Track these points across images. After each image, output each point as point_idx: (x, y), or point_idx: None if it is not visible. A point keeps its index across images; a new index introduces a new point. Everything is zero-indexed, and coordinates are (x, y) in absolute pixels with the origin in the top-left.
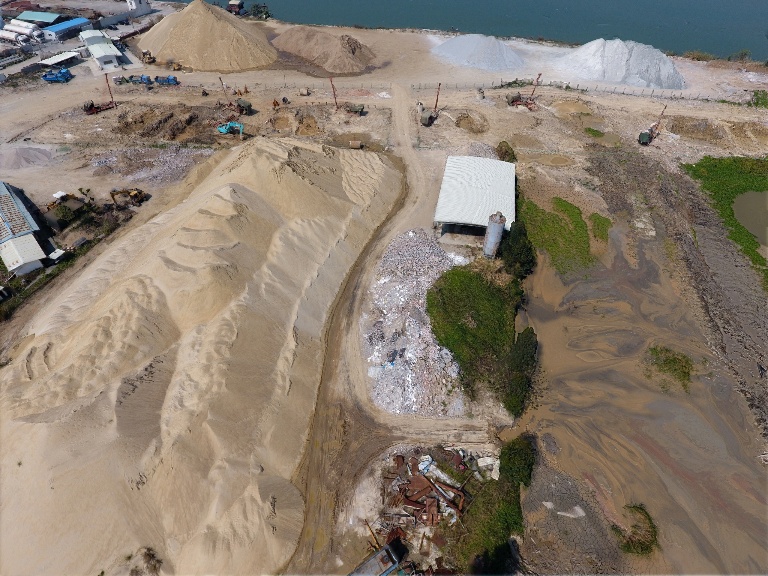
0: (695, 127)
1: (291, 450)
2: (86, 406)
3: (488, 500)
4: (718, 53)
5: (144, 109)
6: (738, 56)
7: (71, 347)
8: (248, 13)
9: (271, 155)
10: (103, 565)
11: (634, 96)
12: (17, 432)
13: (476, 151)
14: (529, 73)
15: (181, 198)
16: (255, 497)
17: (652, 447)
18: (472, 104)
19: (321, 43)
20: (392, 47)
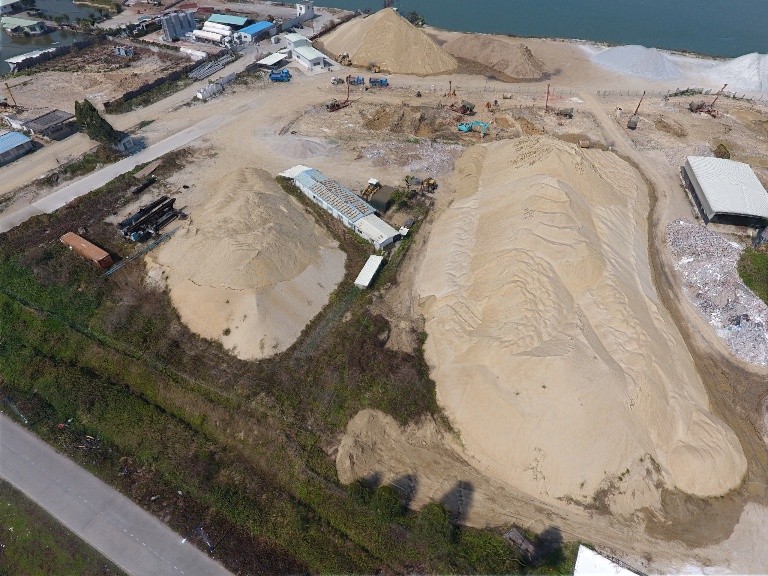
0: None
1: (700, 389)
2: (574, 345)
3: None
4: None
5: (376, 108)
6: None
7: (492, 304)
8: None
9: None
10: (626, 464)
11: None
12: (526, 364)
13: (702, 152)
14: (691, 83)
15: (475, 187)
16: (706, 421)
17: None
18: (659, 110)
19: (498, 50)
20: (553, 55)
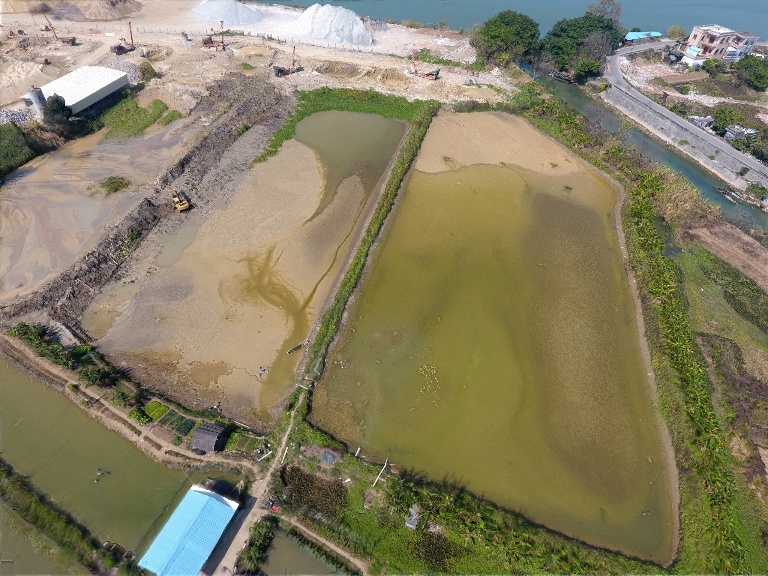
0: (343, 70)
1: None
2: None
3: None
4: None
5: None
6: (438, 25)
7: None
8: None
9: None
10: None
11: (320, 47)
12: None
13: (118, 67)
14: (254, 28)
15: None
16: None
17: (43, 217)
18: (174, 44)
19: None
20: (162, 5)
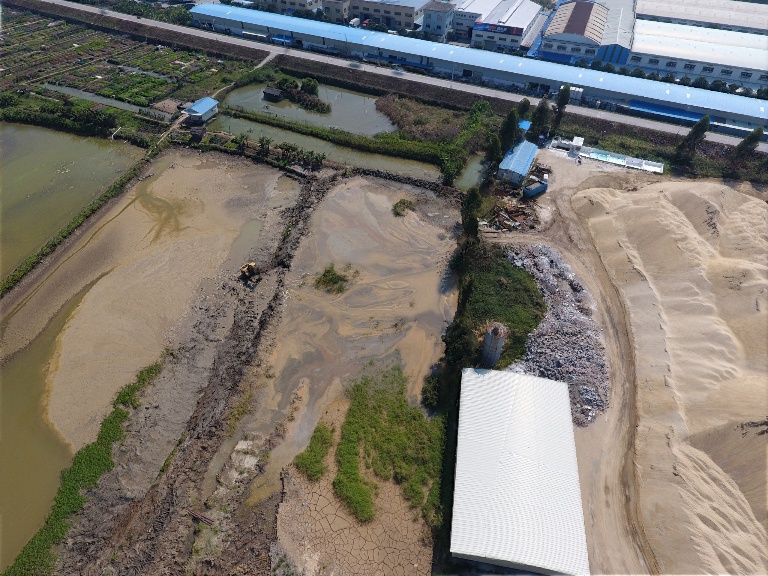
0: None
1: None
2: (720, 195)
3: None
4: None
5: None
6: None
7: None
8: None
9: None
10: None
11: None
12: None
13: None
14: None
15: None
16: None
17: (377, 237)
18: None
19: None
20: None
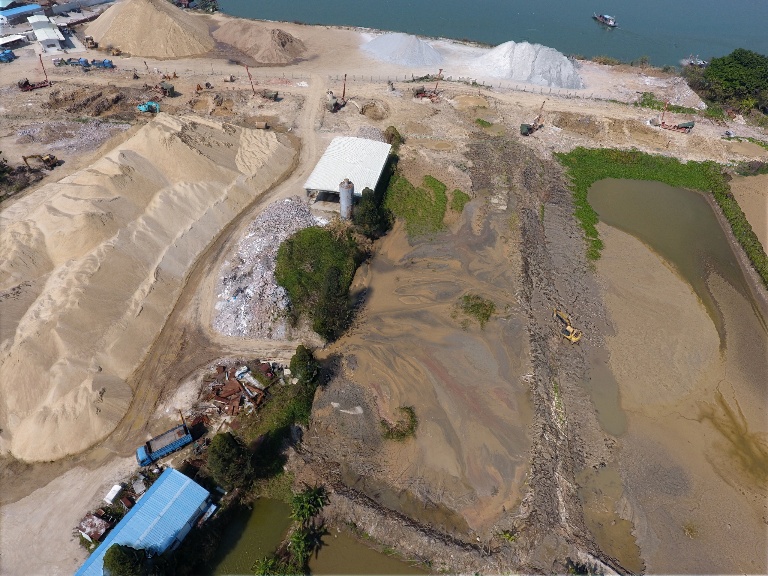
0: (579, 122)
1: (131, 358)
2: None
3: (283, 398)
4: (625, 59)
5: (76, 88)
6: (639, 62)
7: None
8: (198, 6)
9: (164, 127)
10: None
11: (533, 93)
12: None
13: (364, 134)
14: (444, 70)
15: (88, 163)
16: (88, 387)
17: (436, 367)
18: (381, 95)
19: (254, 36)
20: (324, 42)
